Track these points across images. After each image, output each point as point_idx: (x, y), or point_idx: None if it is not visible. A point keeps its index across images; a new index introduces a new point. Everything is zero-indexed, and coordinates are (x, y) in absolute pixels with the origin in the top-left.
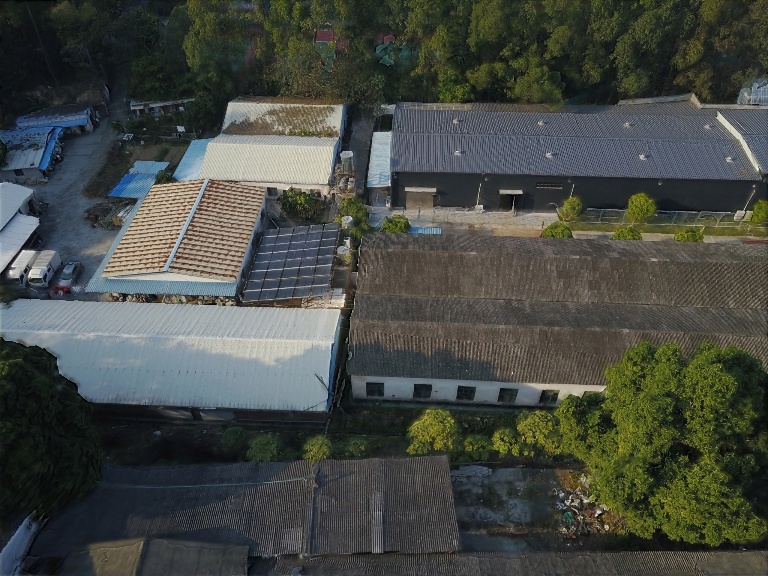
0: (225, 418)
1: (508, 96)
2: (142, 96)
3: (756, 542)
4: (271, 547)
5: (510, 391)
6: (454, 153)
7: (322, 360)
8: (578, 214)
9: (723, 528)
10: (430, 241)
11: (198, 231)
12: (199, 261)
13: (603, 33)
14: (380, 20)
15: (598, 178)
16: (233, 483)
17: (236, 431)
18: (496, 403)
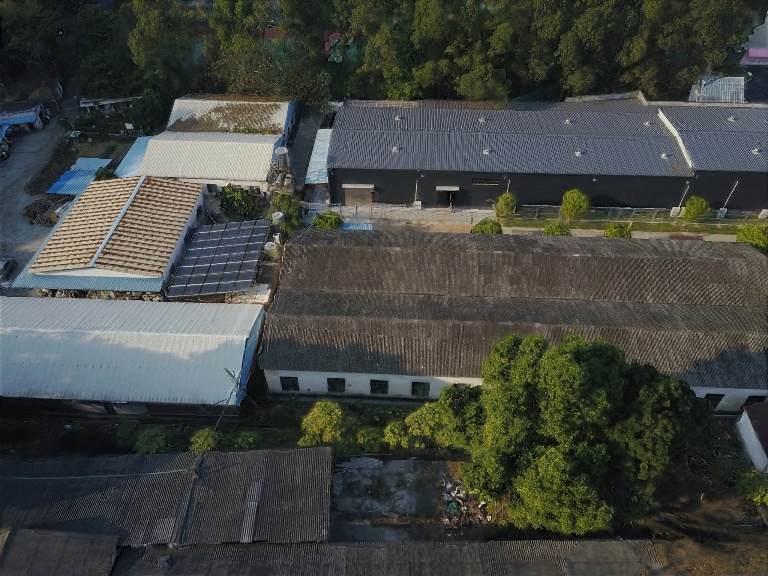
0: (139, 412)
1: (458, 93)
2: (92, 93)
3: (633, 532)
4: (141, 537)
5: (422, 385)
6: (392, 150)
7: (235, 354)
8: (516, 210)
9: (575, 516)
10: (358, 237)
11: (129, 227)
12: (126, 257)
13: (546, 30)
14: (324, 17)
15: (532, 174)
16: (116, 474)
17: (132, 424)
18: (411, 397)
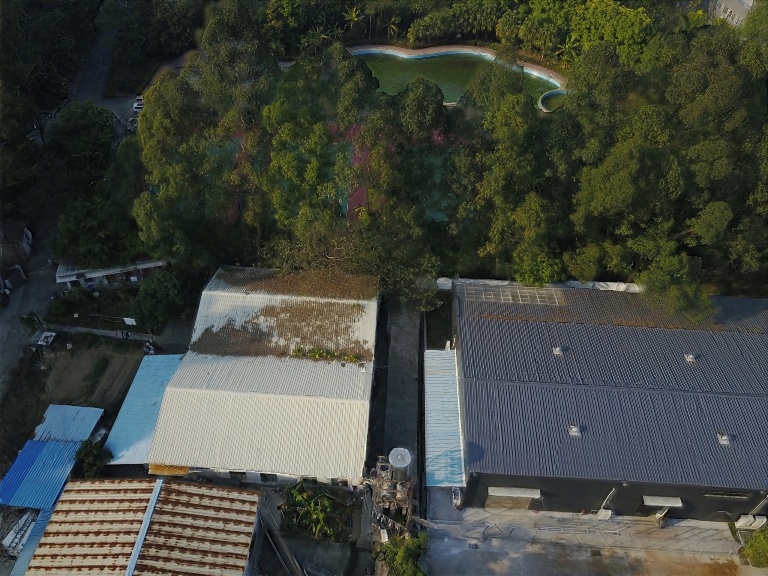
0: None
1: (608, 269)
2: (75, 259)
3: None
4: None
5: None
6: (569, 431)
7: None
8: (761, 526)
9: None
10: None
11: None
12: None
13: None
14: (439, 179)
15: None
16: None
17: None
18: None
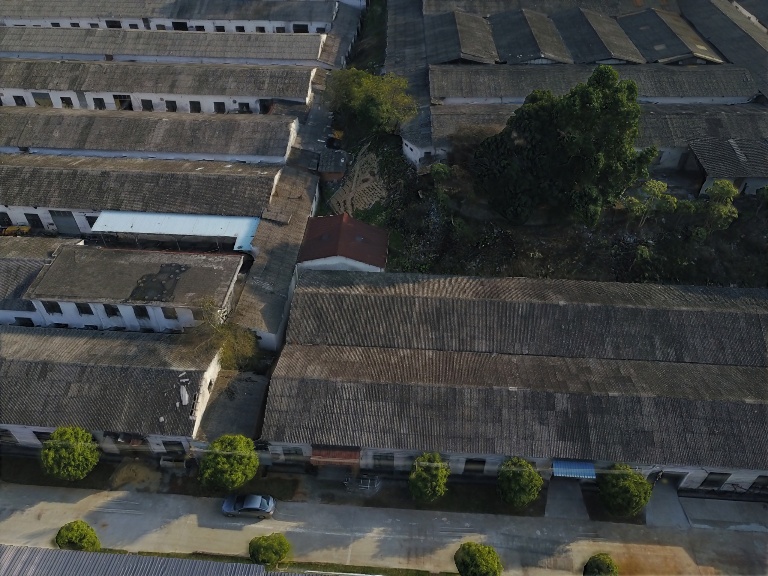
0: None
1: None
2: None
3: None
4: None
5: None
6: None
7: None
8: None
9: None
10: None
11: None
12: None
13: None
14: None
15: None
16: None
17: None
18: None
